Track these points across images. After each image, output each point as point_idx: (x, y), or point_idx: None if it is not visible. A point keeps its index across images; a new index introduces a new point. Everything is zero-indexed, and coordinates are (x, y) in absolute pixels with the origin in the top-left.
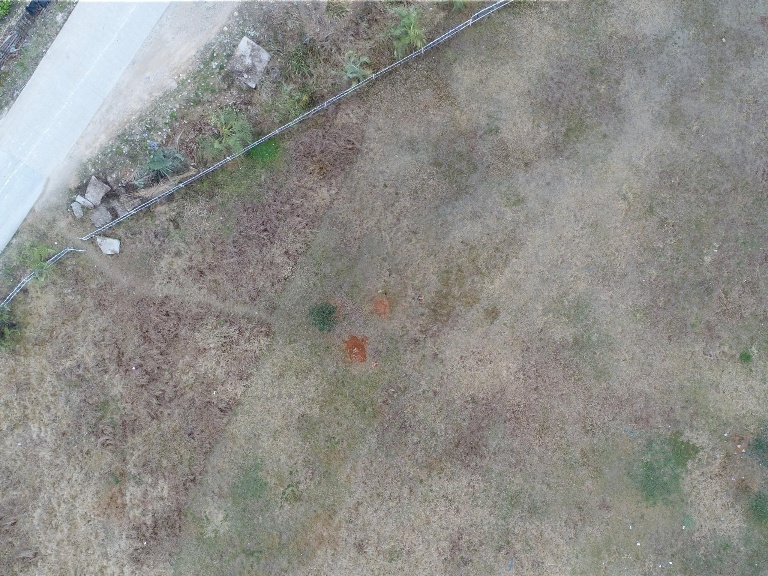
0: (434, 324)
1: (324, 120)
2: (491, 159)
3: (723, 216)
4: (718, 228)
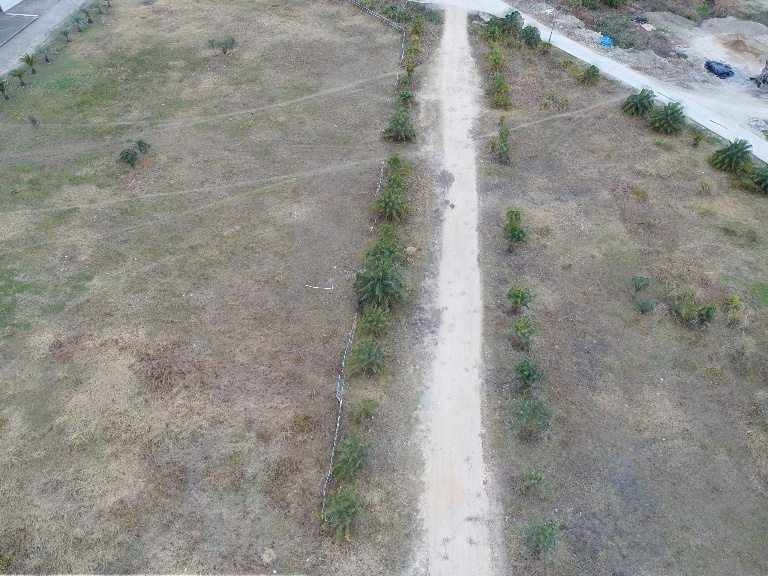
0: None
1: (345, 1)
2: None
3: (314, 51)
4: None
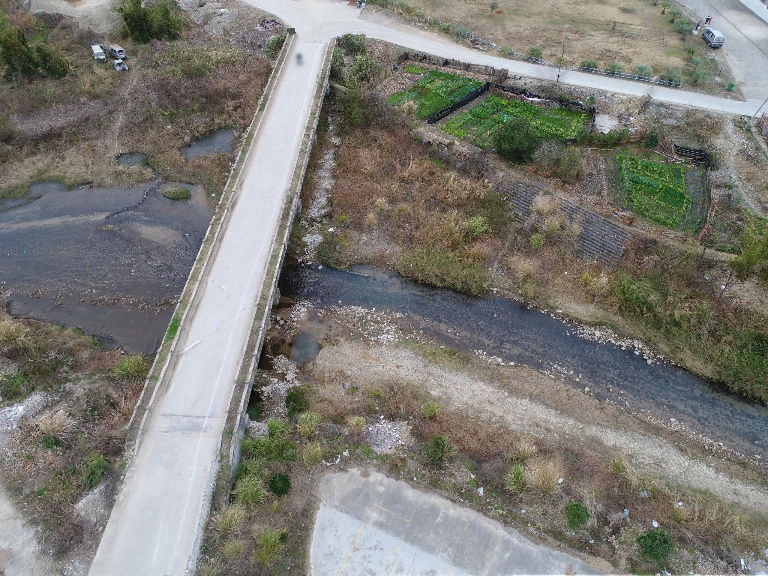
0: (485, 4)
1: None
2: (432, 1)
3: None
4: None
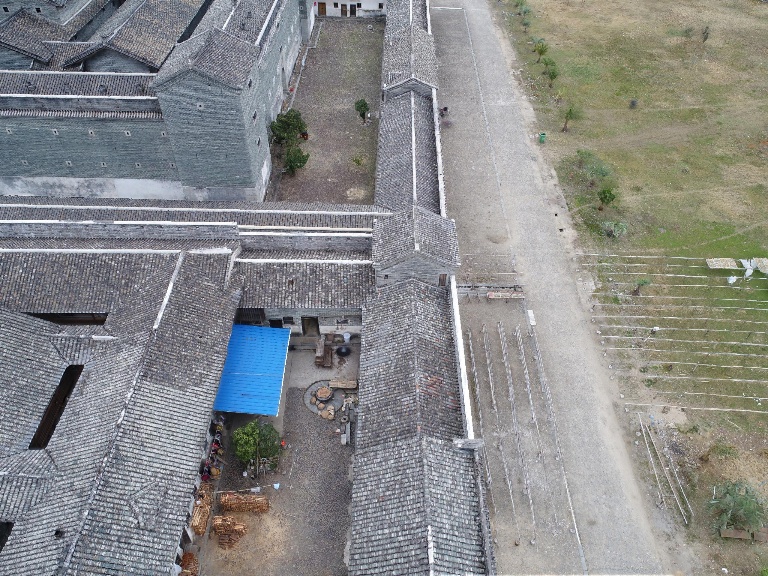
0: None
1: None
2: None
3: None
4: (764, 38)
